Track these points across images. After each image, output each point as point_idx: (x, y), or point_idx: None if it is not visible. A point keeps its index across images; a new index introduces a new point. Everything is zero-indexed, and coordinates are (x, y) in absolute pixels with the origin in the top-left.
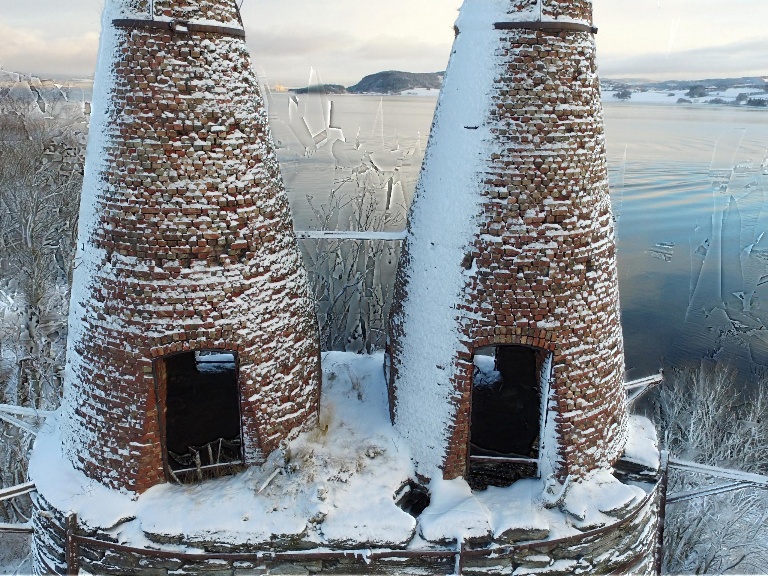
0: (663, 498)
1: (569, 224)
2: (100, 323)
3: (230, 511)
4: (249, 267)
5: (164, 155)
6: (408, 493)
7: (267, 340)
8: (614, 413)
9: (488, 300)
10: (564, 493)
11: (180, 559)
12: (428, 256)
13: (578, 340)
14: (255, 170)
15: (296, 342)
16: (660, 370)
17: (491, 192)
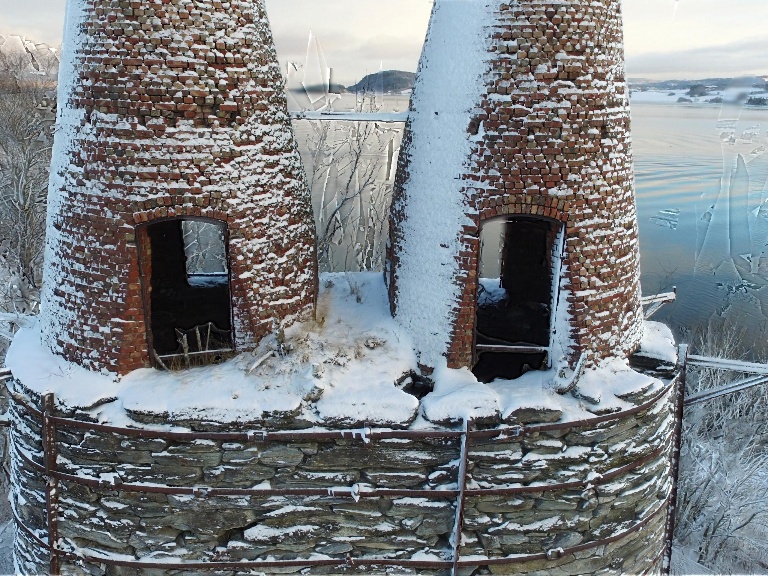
0: (681, 396)
1: (583, 82)
2: (79, 190)
3: (219, 389)
4: (239, 133)
5: (147, 1)
6: (410, 385)
7: (259, 215)
8: (629, 300)
9: (496, 166)
10: (577, 374)
11: (165, 440)
12: (431, 127)
13: (592, 212)
14: (246, 29)
15: (290, 224)
16: (673, 288)
17: (499, 47)
